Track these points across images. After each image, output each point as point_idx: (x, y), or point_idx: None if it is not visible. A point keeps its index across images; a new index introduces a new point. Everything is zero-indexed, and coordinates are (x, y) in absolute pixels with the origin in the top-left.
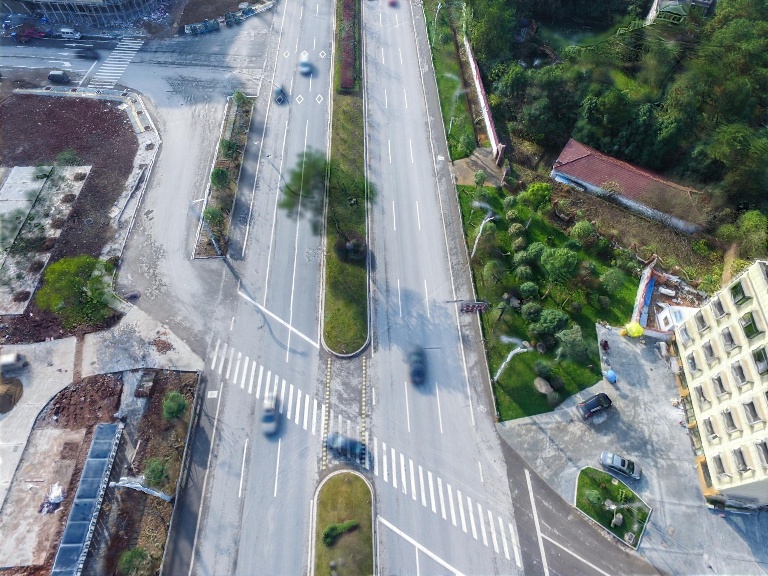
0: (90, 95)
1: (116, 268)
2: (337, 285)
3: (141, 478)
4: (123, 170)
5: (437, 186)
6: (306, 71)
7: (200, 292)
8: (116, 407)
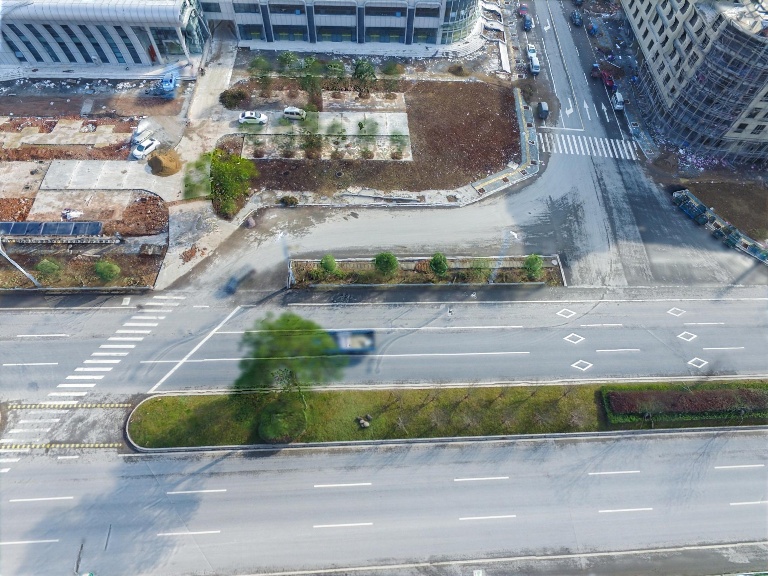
0: (525, 138)
1: (284, 205)
2: (225, 407)
3: (68, 263)
4: (413, 184)
5: (408, 563)
6: (644, 342)
7: (246, 273)
8: (136, 234)
